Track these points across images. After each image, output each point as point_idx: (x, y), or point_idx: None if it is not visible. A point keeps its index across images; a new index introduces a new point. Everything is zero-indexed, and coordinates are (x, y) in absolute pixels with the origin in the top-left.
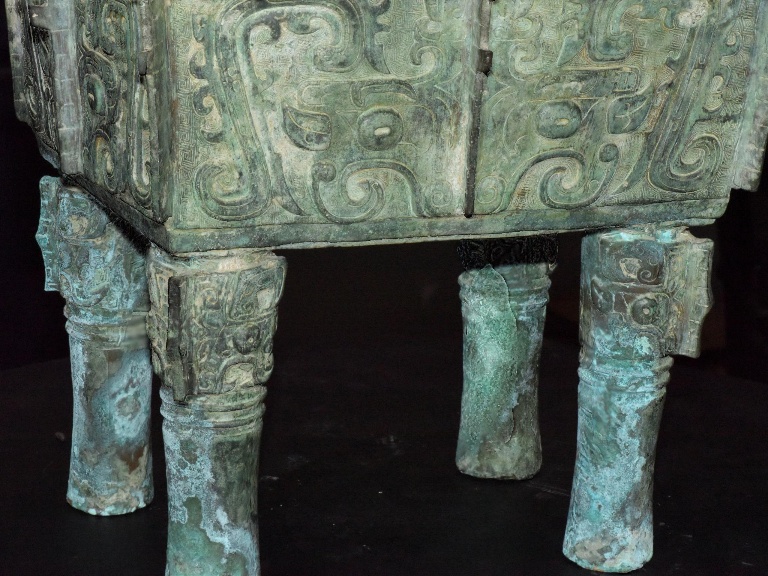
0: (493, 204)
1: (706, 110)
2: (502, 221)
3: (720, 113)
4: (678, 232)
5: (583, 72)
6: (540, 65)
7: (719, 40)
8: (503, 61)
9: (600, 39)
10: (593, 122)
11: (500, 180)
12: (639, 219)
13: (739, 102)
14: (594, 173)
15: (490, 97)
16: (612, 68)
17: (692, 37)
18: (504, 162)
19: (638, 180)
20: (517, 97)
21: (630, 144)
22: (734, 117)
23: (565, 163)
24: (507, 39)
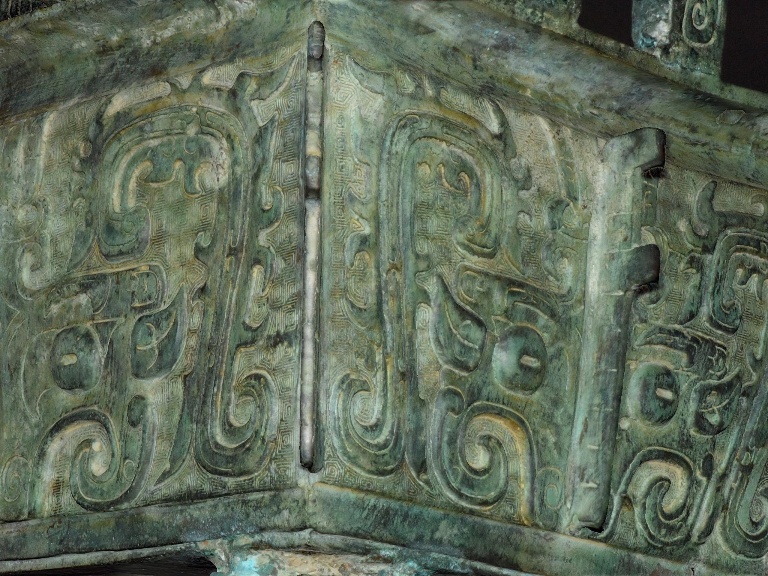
0: (17, 502)
1: (249, 327)
2: (46, 536)
3: (269, 331)
4: (285, 568)
5: (89, 277)
6: (50, 275)
7: (254, 204)
8: (11, 273)
9: (103, 221)
10: (115, 360)
11: (24, 463)
12: (197, 531)
13: (293, 309)
14: (127, 448)
15: (5, 331)
16: (128, 269)
17: (224, 205)
18: (28, 434)
19: (182, 459)
20: (30, 328)
21: (169, 397)
22: (289, 337)
23: (98, 434)
24: (14, 240)
